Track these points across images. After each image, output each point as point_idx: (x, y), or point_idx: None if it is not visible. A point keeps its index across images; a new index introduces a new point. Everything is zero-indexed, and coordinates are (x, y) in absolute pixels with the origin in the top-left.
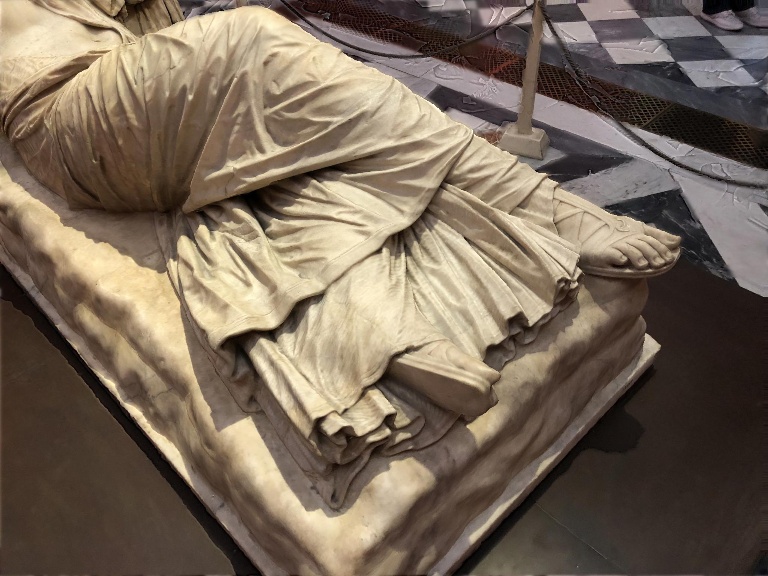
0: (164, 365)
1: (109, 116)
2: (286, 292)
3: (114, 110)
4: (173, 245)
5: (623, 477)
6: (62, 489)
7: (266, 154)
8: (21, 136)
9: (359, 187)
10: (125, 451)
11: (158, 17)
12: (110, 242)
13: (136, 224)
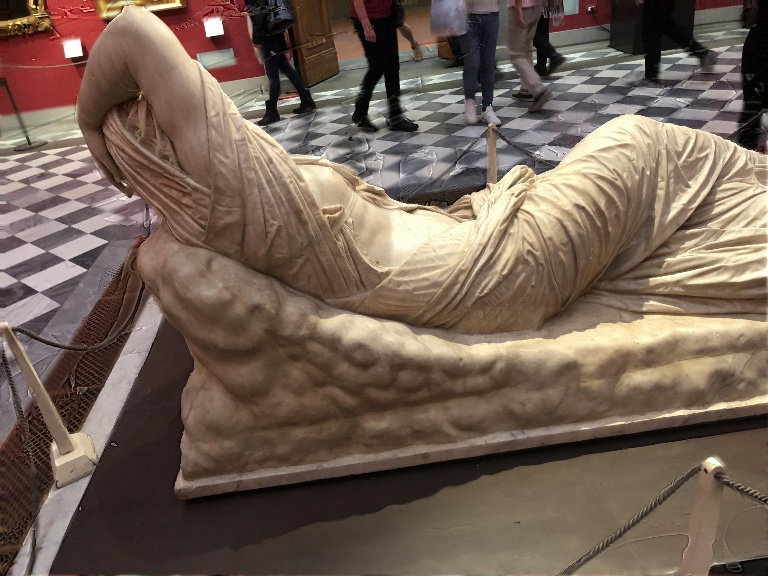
0: (744, 338)
1: (605, 212)
2: None
3: (605, 207)
4: (627, 300)
5: None
6: (758, 478)
7: (692, 187)
8: (489, 290)
9: (733, 182)
10: (728, 443)
11: None
12: (600, 322)
13: (584, 309)
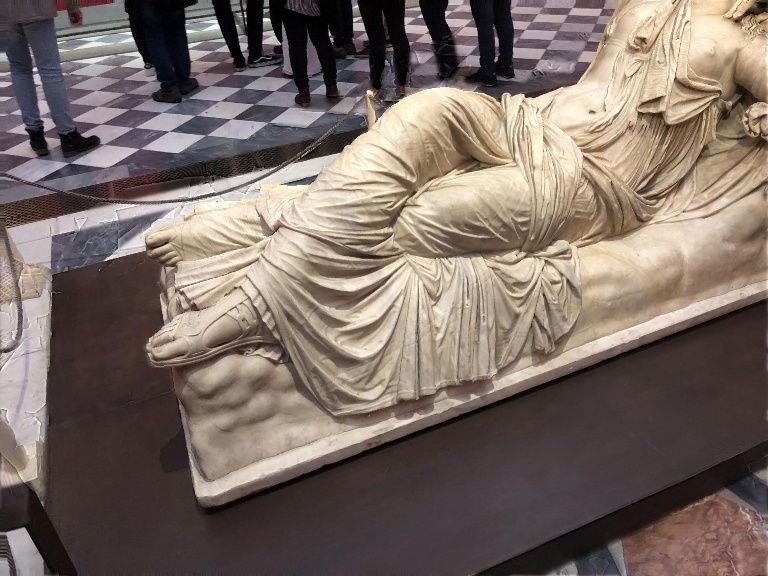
0: None
1: None
2: (268, 195)
3: None
4: None
5: (150, 441)
6: None
7: None
8: None
9: None
10: None
11: (764, 162)
12: None
13: None
